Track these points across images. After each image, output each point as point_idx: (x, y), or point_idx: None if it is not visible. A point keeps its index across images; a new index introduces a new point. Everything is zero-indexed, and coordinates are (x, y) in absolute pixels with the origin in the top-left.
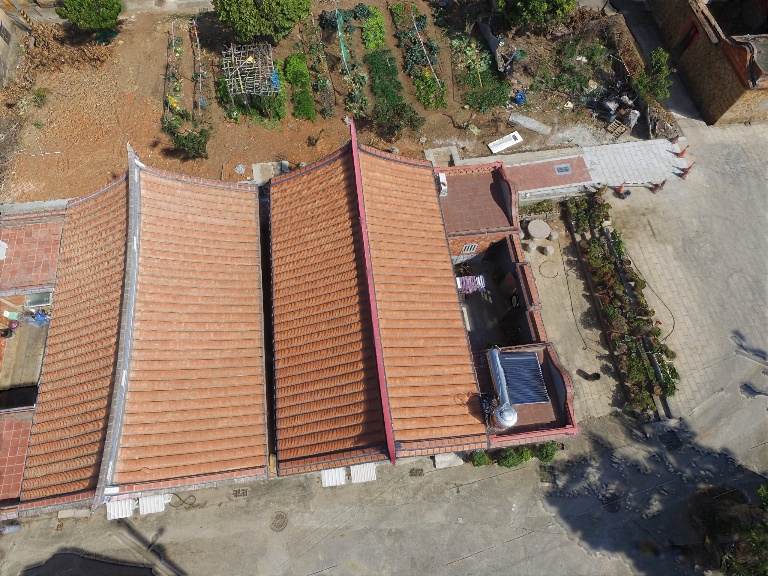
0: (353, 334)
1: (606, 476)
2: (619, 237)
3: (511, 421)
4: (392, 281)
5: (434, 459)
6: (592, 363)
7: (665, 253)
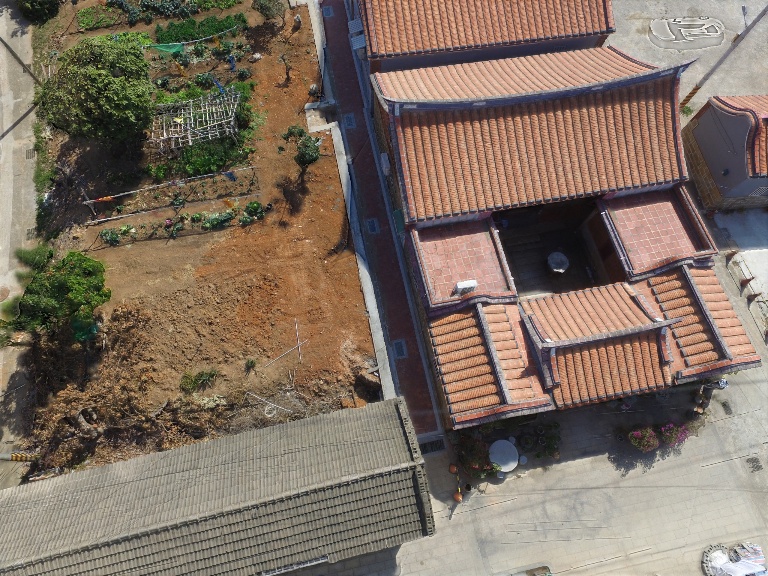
0: None
1: None
2: None
3: None
4: None
5: None
6: None
7: None
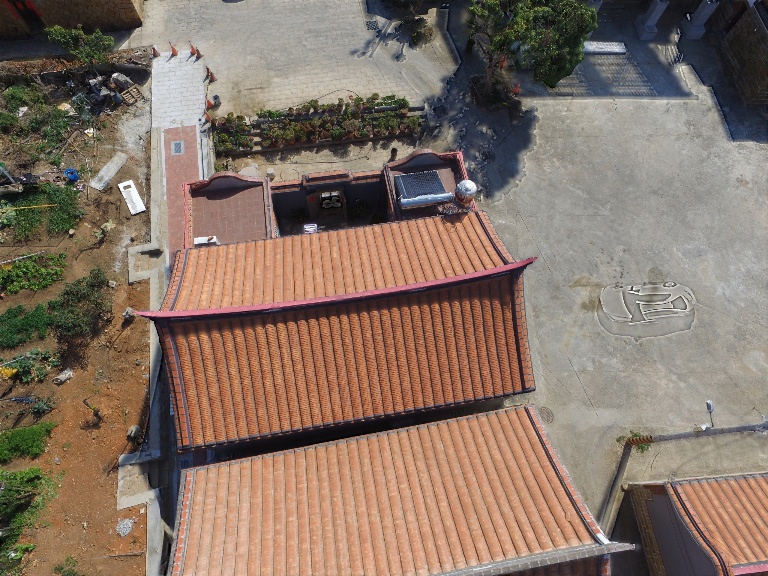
0: (403, 317)
1: (471, 157)
2: (265, 111)
3: (473, 184)
4: (341, 282)
5: None
6: (380, 155)
7: (281, 84)
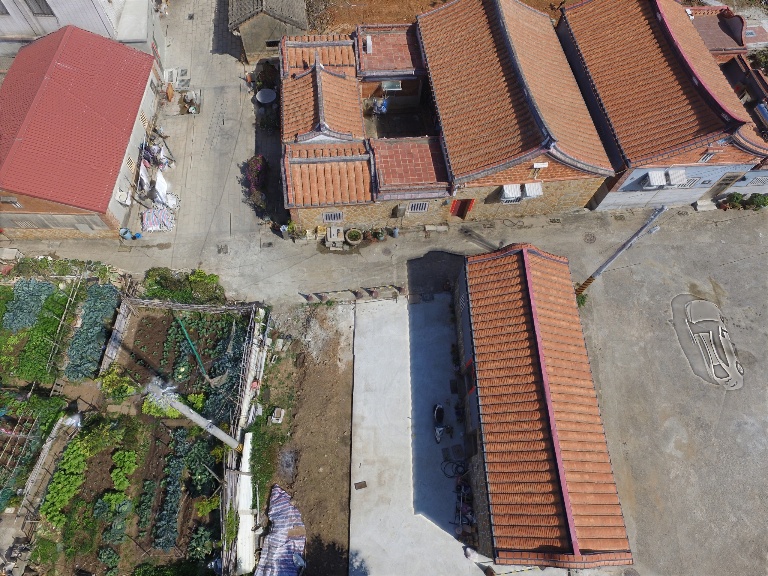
0: (670, 82)
1: None
2: None
3: None
4: None
5: (695, 205)
6: None
7: None
